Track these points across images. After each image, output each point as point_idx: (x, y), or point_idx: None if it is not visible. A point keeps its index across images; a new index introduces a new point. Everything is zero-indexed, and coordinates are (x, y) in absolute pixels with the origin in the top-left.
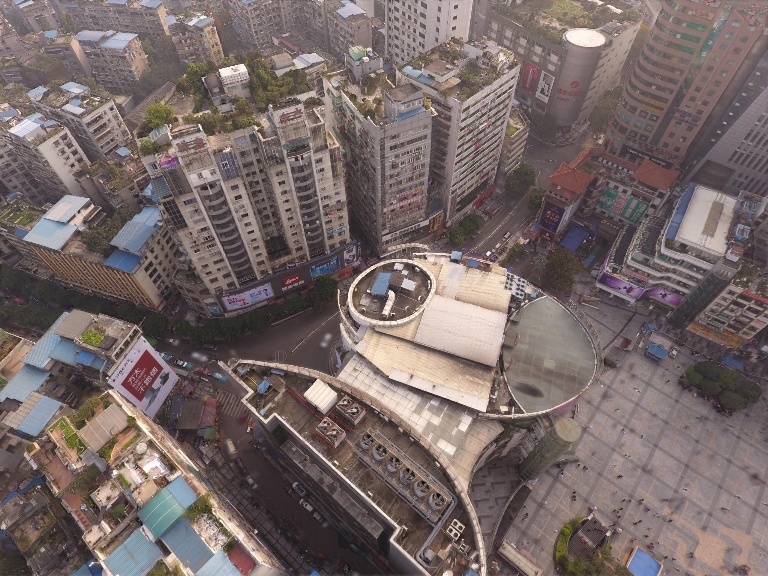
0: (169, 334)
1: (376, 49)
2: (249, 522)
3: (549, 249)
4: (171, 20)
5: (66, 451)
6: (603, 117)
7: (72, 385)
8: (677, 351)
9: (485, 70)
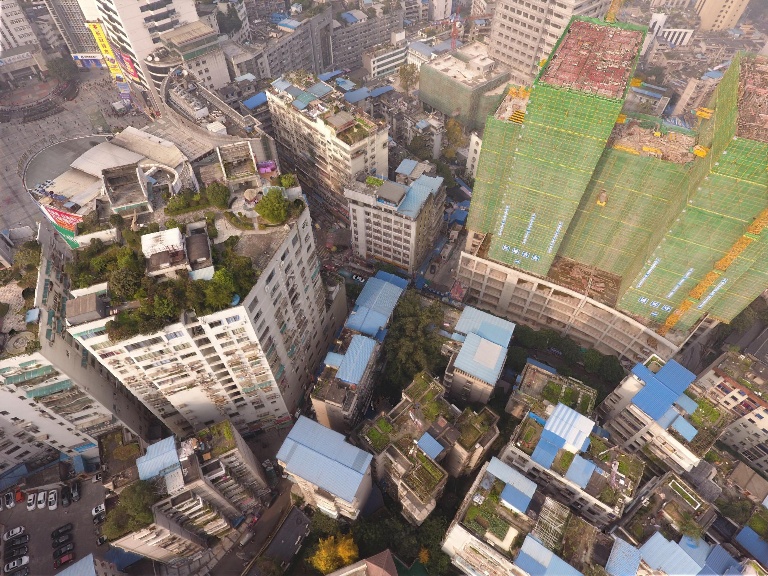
0: None
1: None
2: (303, 183)
3: None
4: None
5: (363, 118)
6: None
7: None
8: None
9: None
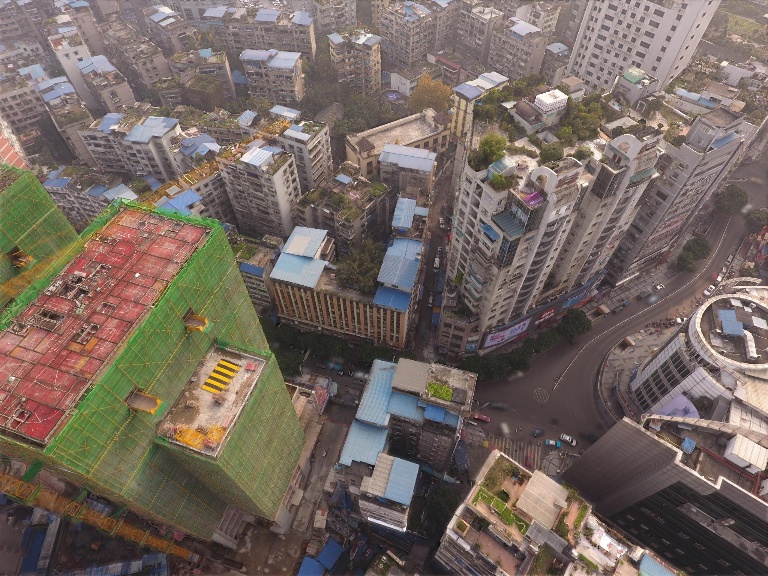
0: None
1: (543, 67)
2: None
3: None
4: (337, 38)
5: (505, 528)
6: None
7: None
8: None
9: (763, 92)
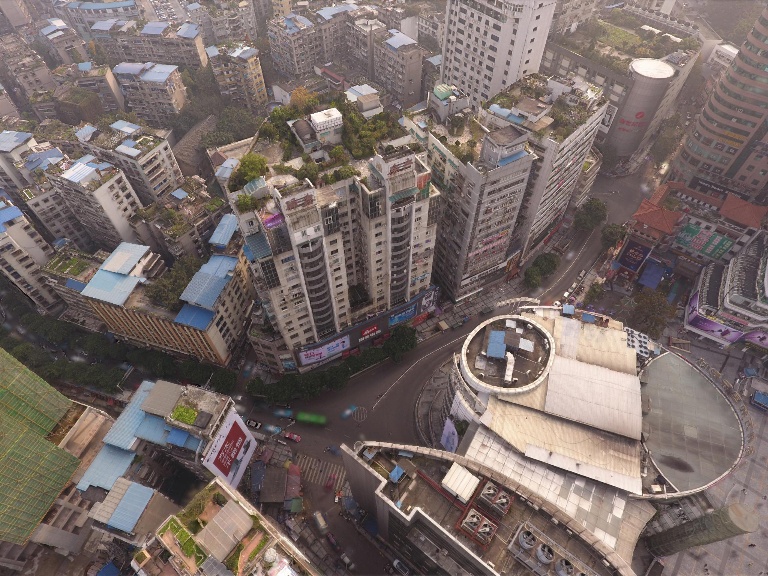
0: (236, 391)
1: (425, 79)
2: None
3: (627, 287)
4: (213, 51)
5: (182, 560)
6: (668, 148)
7: (153, 462)
8: None
9: (576, 108)
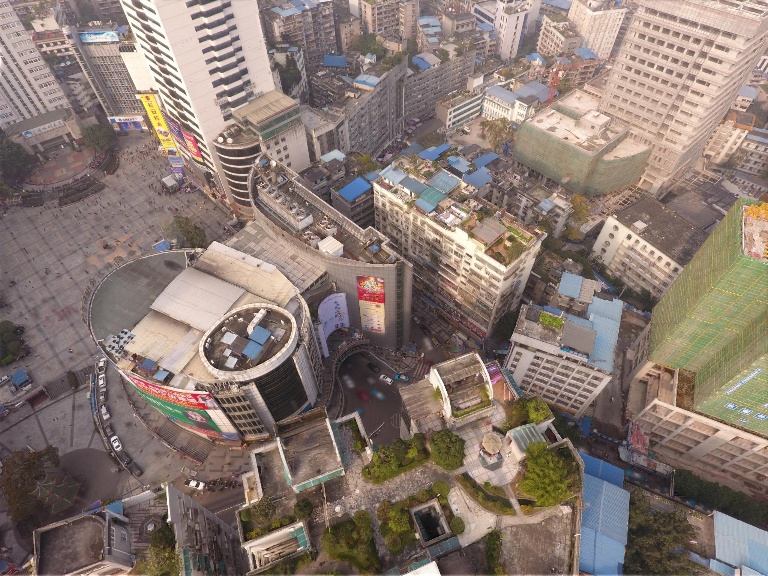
0: None
1: None
2: None
3: (7, 553)
4: None
5: (513, 226)
6: None
7: None
8: (1, 379)
9: None
